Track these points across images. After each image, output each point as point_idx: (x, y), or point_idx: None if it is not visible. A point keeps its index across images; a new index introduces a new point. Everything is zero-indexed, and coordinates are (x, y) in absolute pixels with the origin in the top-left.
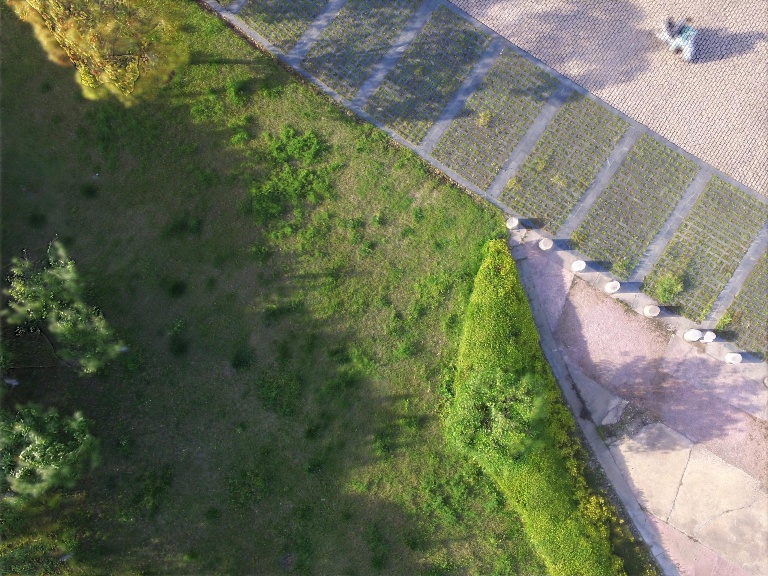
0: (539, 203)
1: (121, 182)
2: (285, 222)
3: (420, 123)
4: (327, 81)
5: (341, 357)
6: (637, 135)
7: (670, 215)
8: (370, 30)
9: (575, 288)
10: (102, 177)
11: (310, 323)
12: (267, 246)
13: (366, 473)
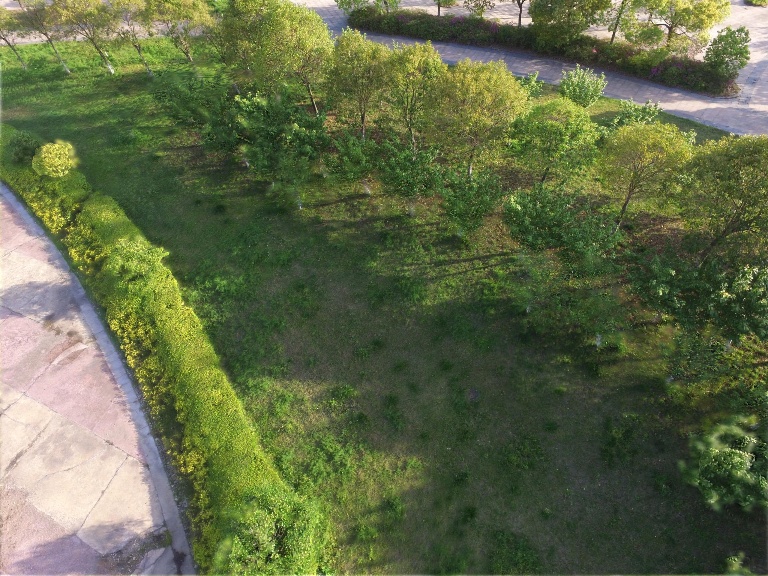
0: None
1: None
2: None
3: None
4: None
5: None
6: None
7: None
8: None
9: None
10: None
11: None
12: None
13: (410, 477)
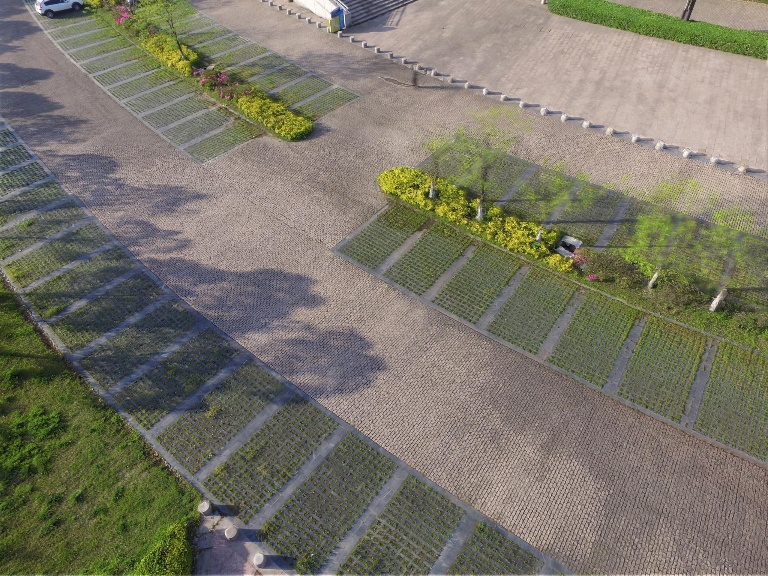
0: (240, 490)
1: None
2: None
3: (157, 411)
4: (95, 374)
5: None
6: (343, 433)
7: (364, 511)
8: (147, 341)
9: None
10: None
11: None
12: None
13: None
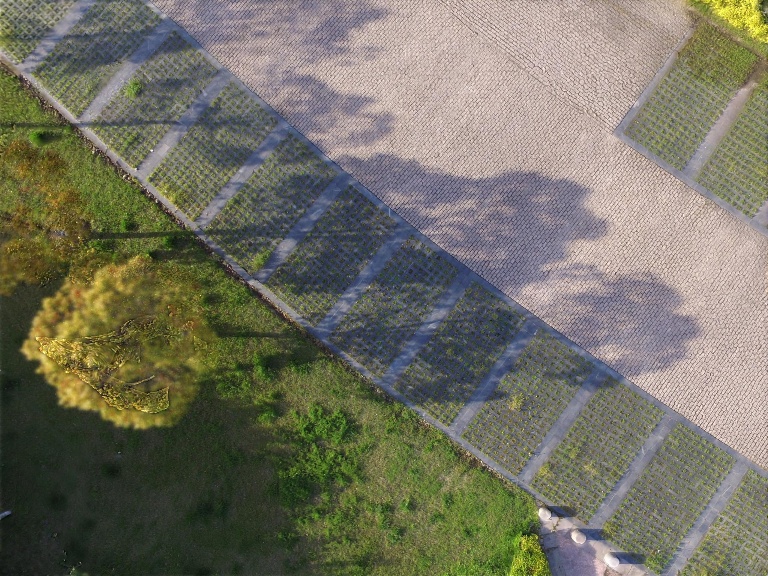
0: (572, 491)
1: (144, 461)
2: (312, 507)
3: (451, 404)
4: (357, 356)
5: None
6: (673, 424)
7: (705, 508)
8: (402, 305)
9: None
10: (124, 455)
11: None
12: (293, 531)
13: None
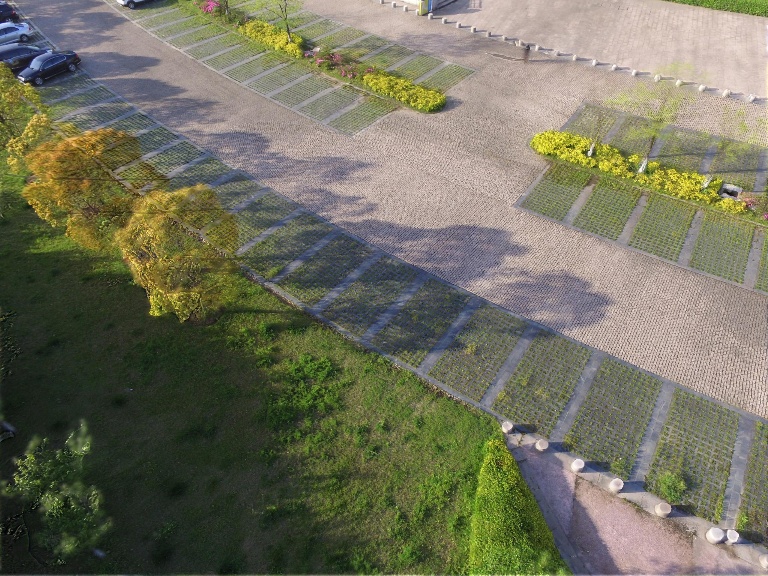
0: (529, 411)
1: (151, 395)
2: (295, 428)
3: (418, 351)
4: (342, 324)
5: (341, 564)
6: (601, 359)
7: (650, 420)
8: (377, 293)
9: (580, 488)
10: (135, 392)
11: (310, 526)
12: (275, 449)
13: None
